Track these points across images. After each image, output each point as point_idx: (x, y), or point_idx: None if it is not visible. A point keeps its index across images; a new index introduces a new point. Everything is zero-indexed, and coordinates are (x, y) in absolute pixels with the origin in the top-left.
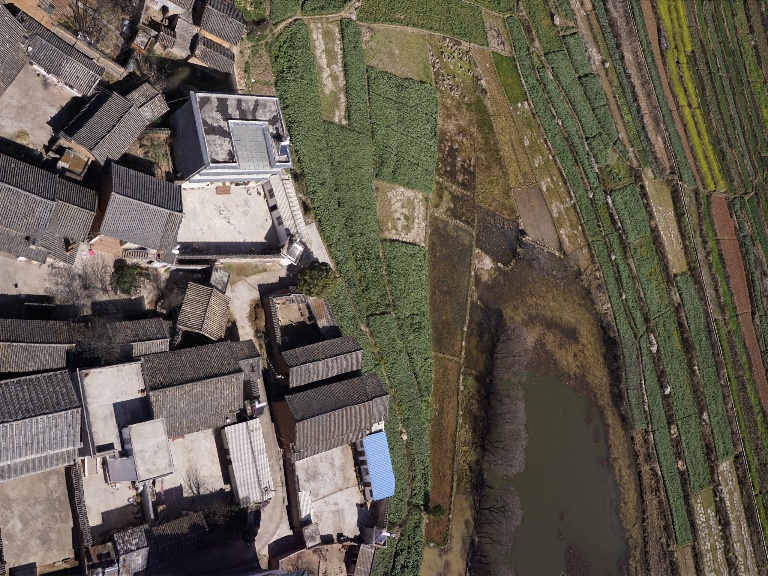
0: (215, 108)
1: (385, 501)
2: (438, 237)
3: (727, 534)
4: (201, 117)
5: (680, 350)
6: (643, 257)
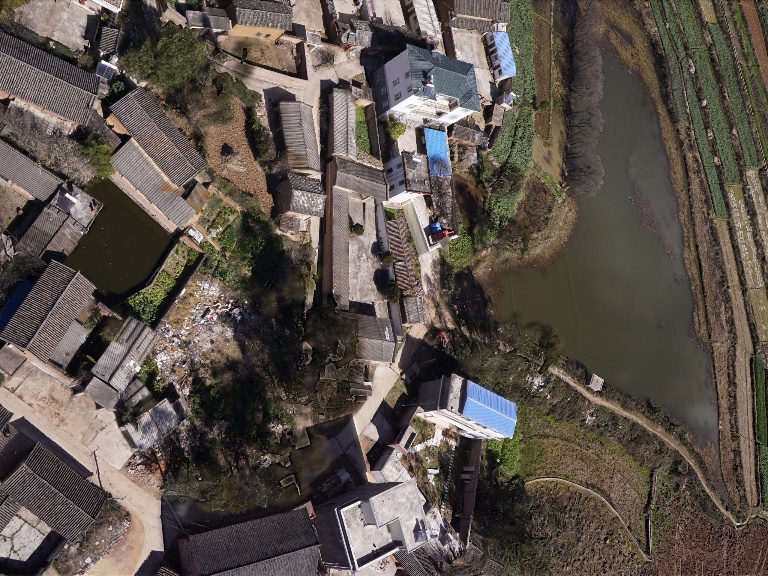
0: None
1: (509, 80)
2: None
3: (755, 222)
4: None
5: (713, 80)
6: (681, 2)
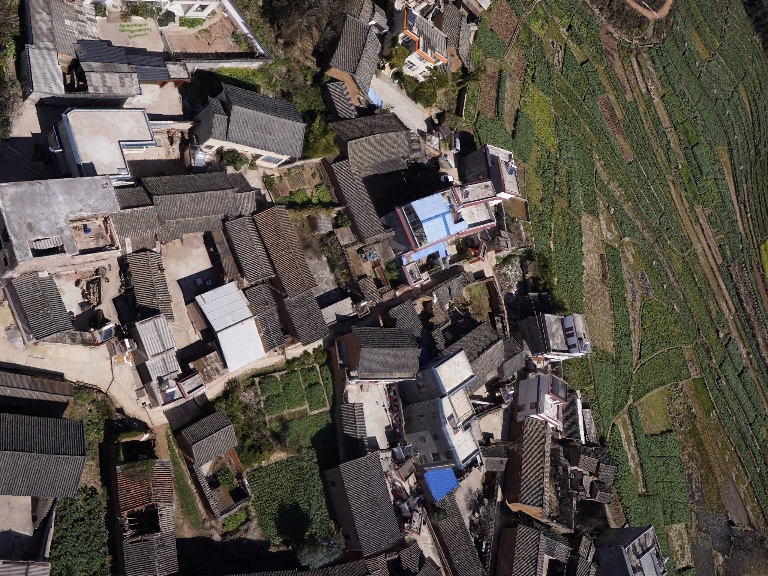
0: (632, 552)
1: None
2: (696, 553)
3: None
4: (630, 565)
5: None
6: None
